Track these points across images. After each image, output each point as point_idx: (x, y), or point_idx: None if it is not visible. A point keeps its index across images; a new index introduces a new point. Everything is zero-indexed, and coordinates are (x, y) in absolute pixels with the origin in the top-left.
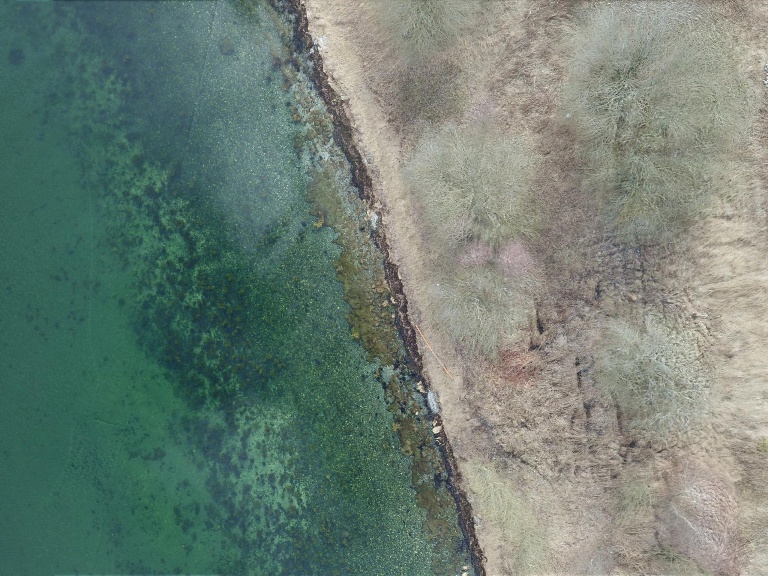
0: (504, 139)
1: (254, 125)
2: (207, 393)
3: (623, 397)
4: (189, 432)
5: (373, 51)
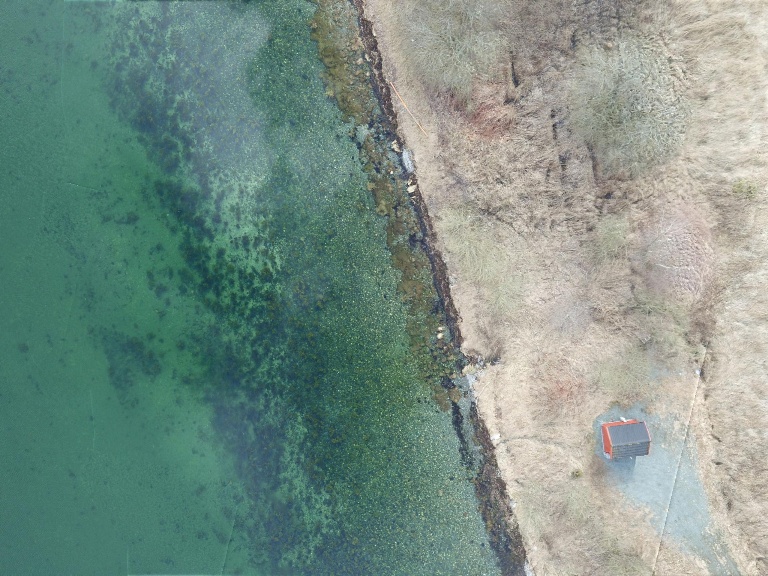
0: None
1: None
2: (180, 156)
3: (599, 148)
4: (162, 196)
5: None
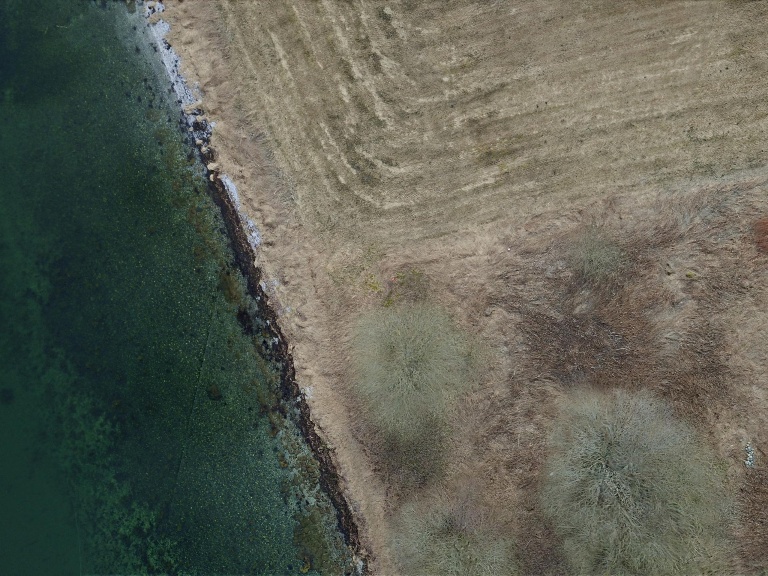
0: (488, 493)
1: (241, 469)
2: None
3: None
4: None
5: (359, 402)
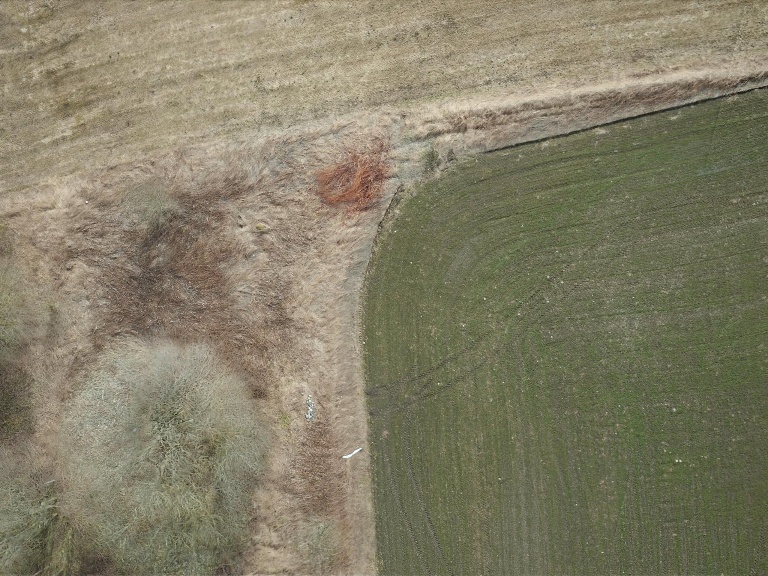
0: (76, 450)
1: None
2: None
3: None
4: None
5: None
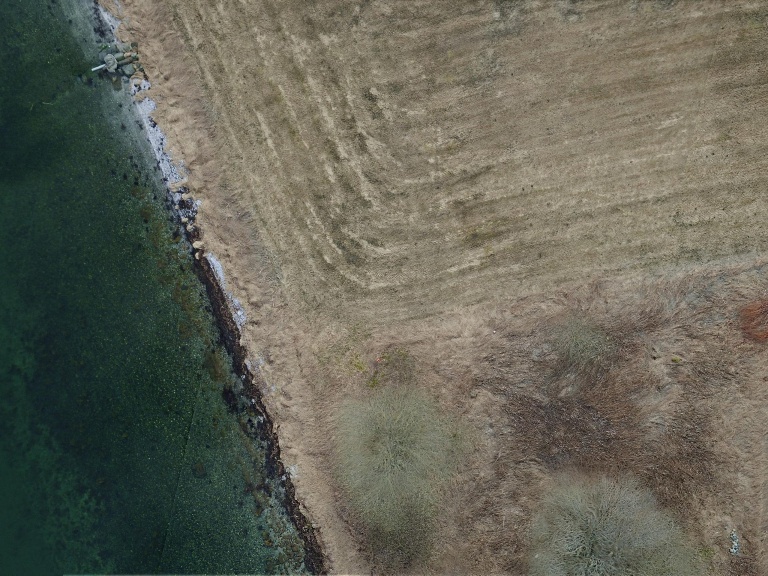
0: (473, 574)
1: (226, 547)
2: None
3: None
4: None
5: (344, 482)
